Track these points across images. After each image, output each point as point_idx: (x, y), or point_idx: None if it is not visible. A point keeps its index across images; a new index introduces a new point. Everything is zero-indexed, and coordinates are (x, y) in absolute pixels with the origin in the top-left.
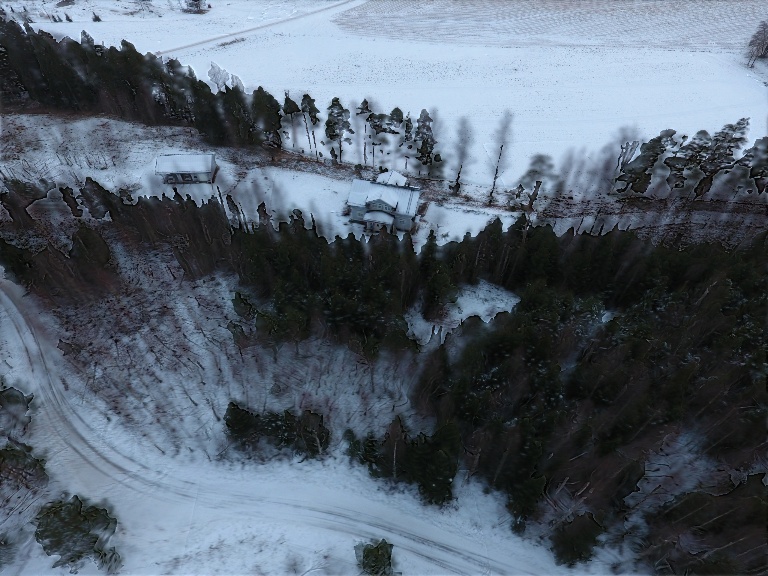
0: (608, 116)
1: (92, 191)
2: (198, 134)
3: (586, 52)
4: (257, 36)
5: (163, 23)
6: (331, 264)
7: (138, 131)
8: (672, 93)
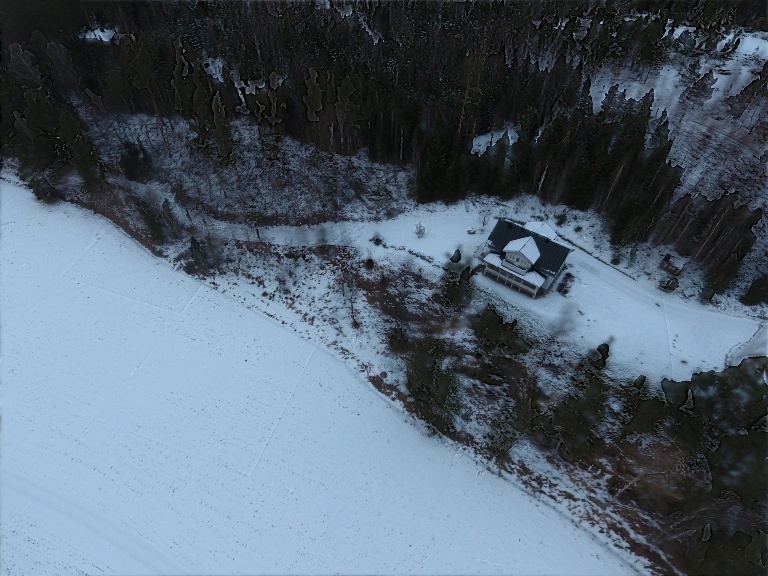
0: None
1: None
2: None
3: None
4: None
5: None
6: None
7: None
8: None
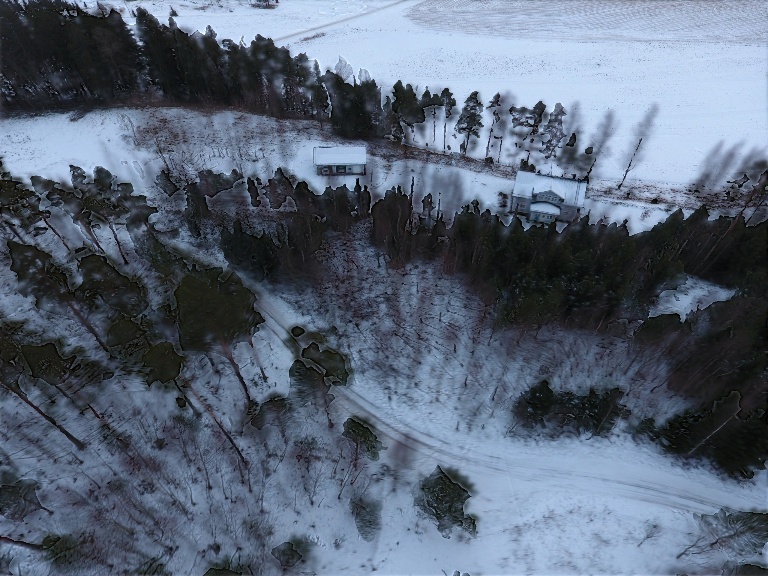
0: (706, 111)
1: (282, 181)
2: (326, 127)
3: (663, 47)
4: (336, 31)
5: (239, 18)
6: (564, 251)
7: (273, 124)
8: (763, 88)
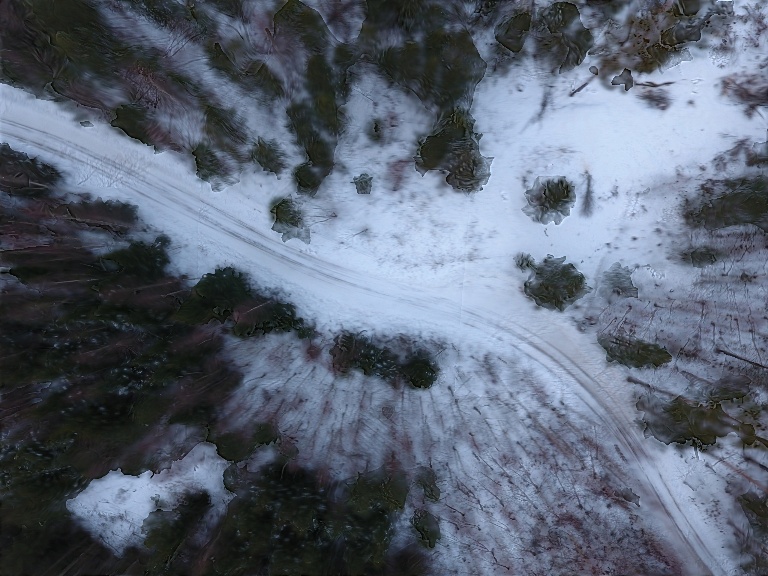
0: None
1: None
2: None
3: None
4: None
5: None
6: None
7: None
8: None
